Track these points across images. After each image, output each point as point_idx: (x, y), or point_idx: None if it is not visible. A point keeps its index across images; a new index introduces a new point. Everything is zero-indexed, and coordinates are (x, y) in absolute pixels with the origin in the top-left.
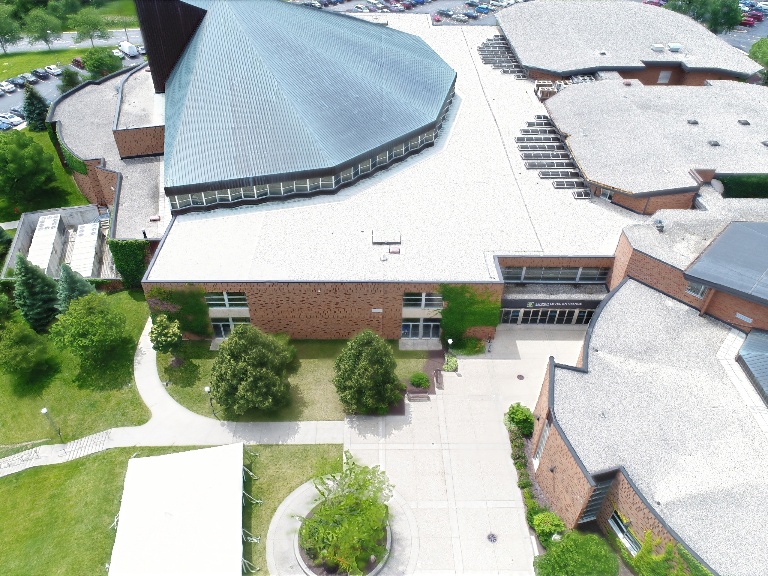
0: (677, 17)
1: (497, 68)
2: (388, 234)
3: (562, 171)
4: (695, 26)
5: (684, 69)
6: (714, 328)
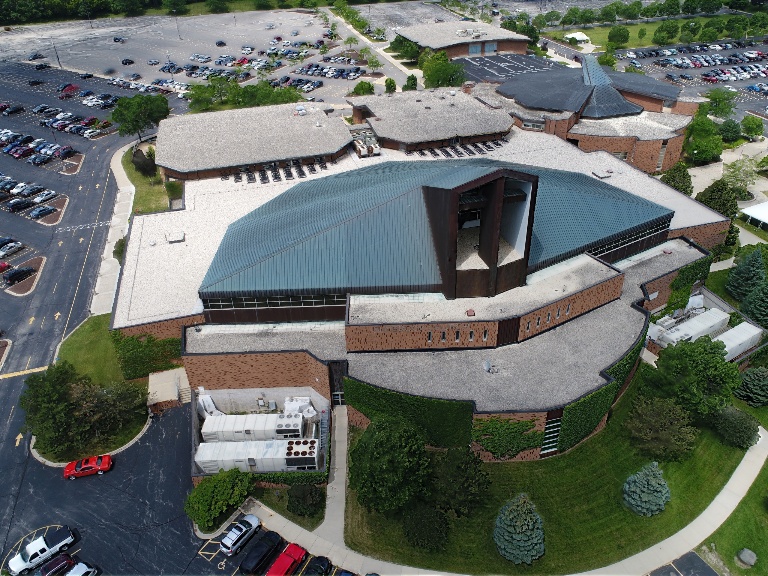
0: (196, 115)
1: (316, 171)
2: (600, 173)
3: (483, 145)
4: (218, 112)
5: (330, 112)
6: (583, 122)
